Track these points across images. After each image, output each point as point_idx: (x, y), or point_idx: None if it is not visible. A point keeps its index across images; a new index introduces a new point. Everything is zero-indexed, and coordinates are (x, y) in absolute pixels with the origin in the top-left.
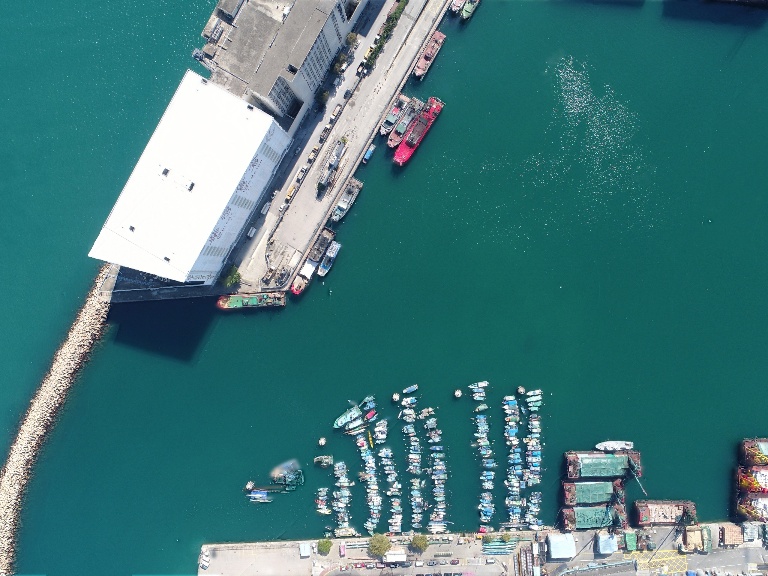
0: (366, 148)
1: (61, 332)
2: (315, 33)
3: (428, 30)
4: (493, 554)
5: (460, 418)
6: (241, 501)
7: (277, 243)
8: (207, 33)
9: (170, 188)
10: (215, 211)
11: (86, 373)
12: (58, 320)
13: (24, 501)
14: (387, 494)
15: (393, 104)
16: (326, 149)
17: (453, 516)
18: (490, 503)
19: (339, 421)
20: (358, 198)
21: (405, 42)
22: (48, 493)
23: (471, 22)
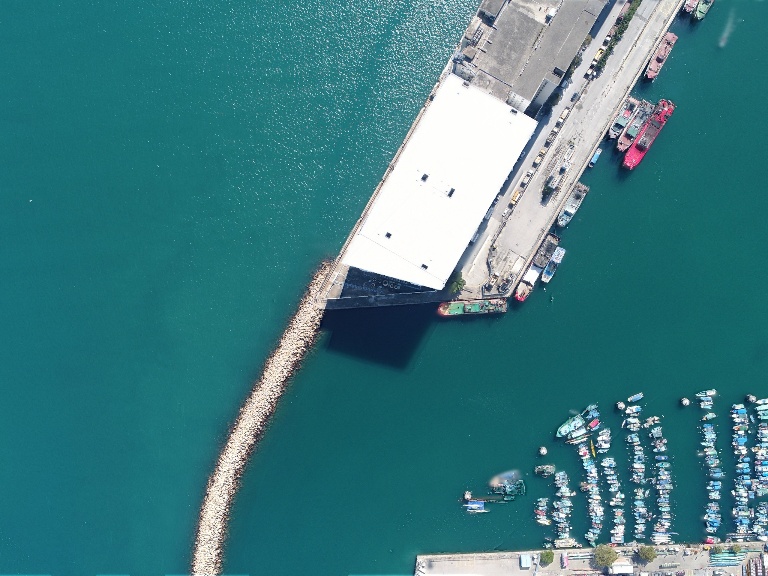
0: (593, 152)
1: (271, 339)
2: (583, 35)
3: (659, 31)
4: (721, 565)
5: (686, 427)
6: (457, 511)
7: (499, 249)
8: (469, 35)
9: (428, 194)
10: (475, 217)
11: (296, 381)
12: (269, 327)
13: (231, 511)
14: (610, 504)
15: (622, 107)
16: (552, 153)
17: (678, 527)
18: (716, 513)
19: (563, 430)
20: (582, 203)
21: (635, 44)
22: (255, 503)
23: (702, 23)
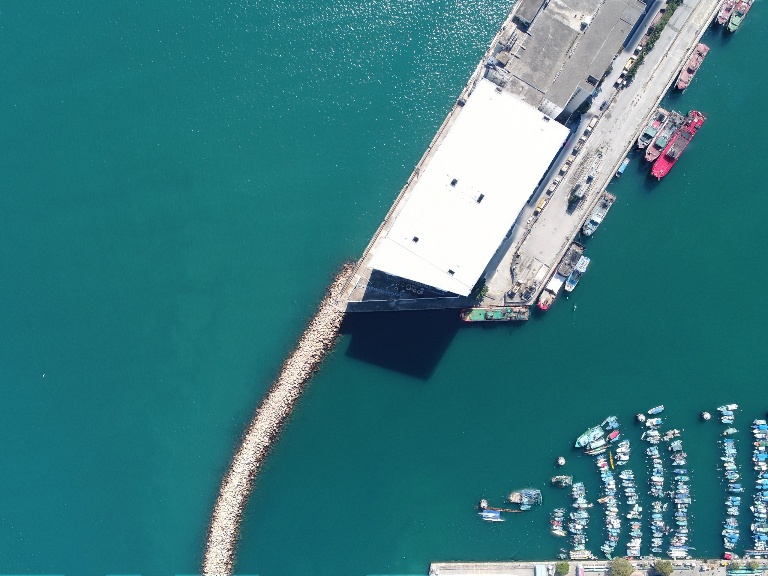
0: (621, 161)
1: (290, 341)
2: (618, 44)
3: (691, 42)
4: None
5: (706, 441)
6: (472, 519)
7: (523, 256)
8: (503, 41)
9: (457, 199)
10: (503, 224)
11: (314, 383)
12: (288, 328)
13: (244, 513)
14: (627, 517)
15: (651, 117)
16: (579, 161)
17: (695, 541)
18: (734, 529)
19: (582, 441)
20: (608, 212)
21: (666, 54)
22: (268, 505)
23: (734, 35)
